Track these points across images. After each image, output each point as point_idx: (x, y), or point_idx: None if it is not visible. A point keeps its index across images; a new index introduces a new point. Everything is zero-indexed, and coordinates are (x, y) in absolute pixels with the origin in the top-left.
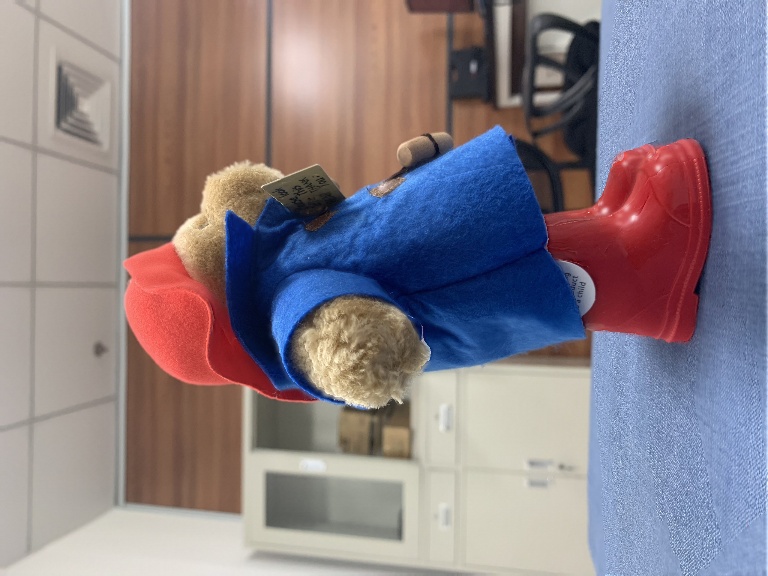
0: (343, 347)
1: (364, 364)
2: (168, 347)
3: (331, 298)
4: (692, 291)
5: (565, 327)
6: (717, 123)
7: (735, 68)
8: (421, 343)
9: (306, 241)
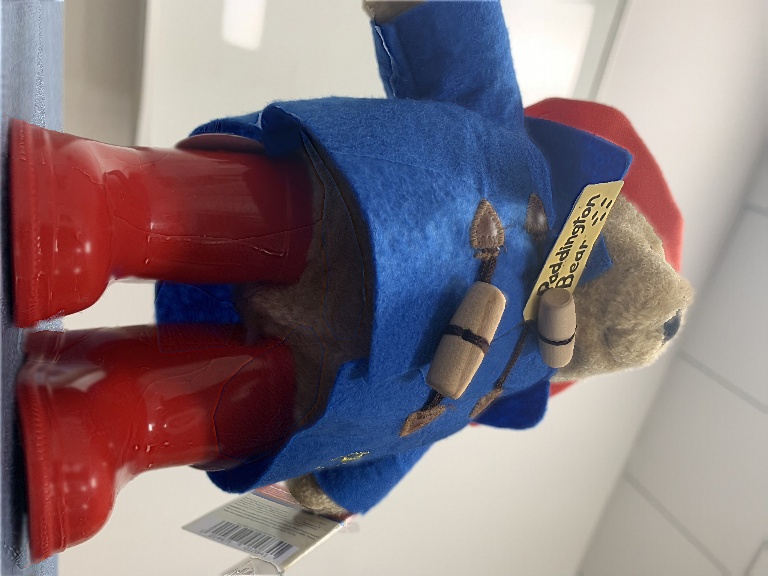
0: None
1: None
2: None
3: None
4: None
5: None
6: None
7: None
8: (374, 6)
9: None
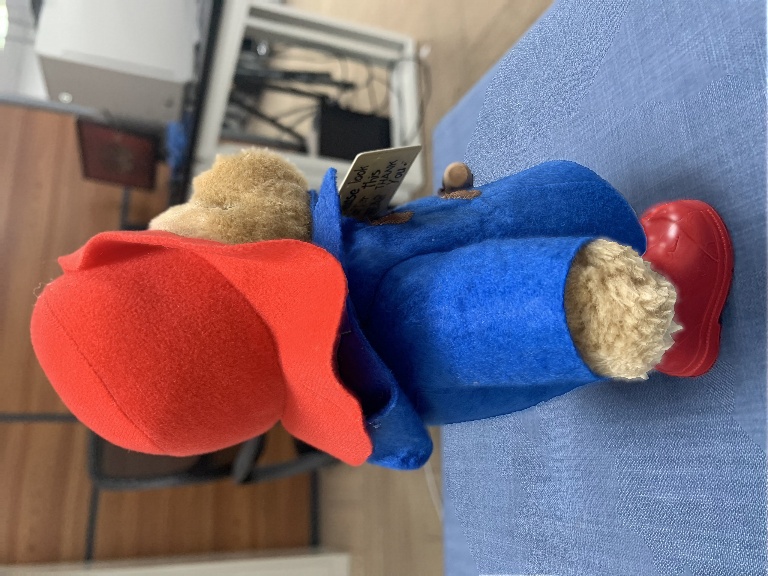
0: (641, 284)
1: (672, 303)
2: (158, 373)
3: (589, 239)
4: (717, 321)
5: None
6: (731, 179)
7: (760, 132)
8: None
9: (401, 230)
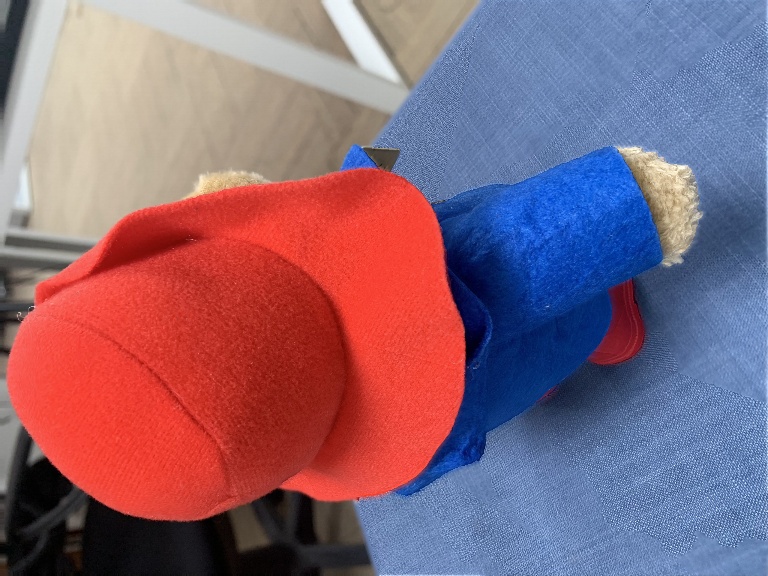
0: None
1: None
2: (231, 356)
3: None
4: (633, 302)
5: (604, 319)
6: None
7: None
8: None
9: None
